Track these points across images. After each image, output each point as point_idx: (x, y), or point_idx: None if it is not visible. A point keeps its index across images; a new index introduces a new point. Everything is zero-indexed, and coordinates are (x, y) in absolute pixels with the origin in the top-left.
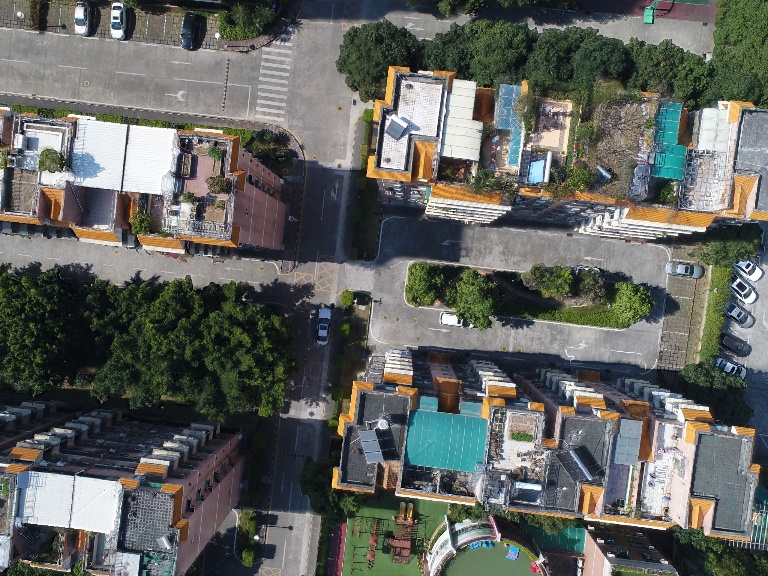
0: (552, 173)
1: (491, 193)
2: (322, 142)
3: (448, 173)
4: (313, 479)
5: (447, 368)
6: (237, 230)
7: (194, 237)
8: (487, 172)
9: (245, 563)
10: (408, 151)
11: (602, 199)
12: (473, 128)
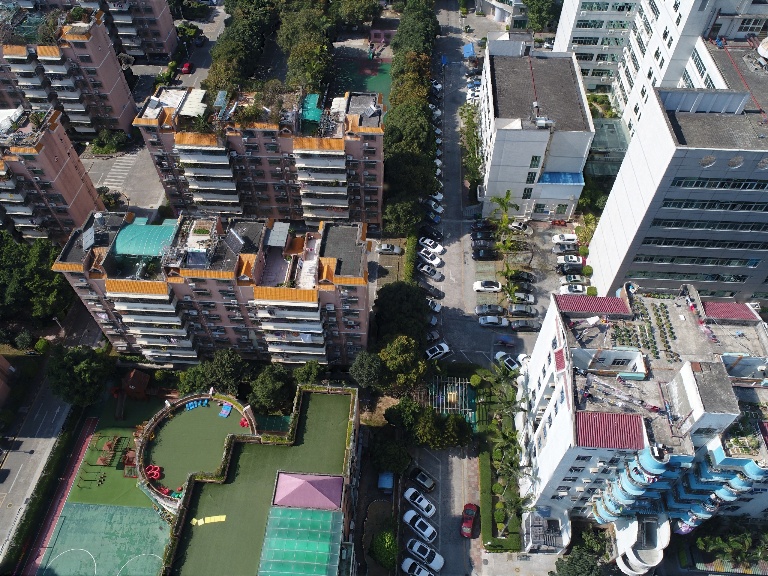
0: (236, 109)
1: (210, 137)
2: (143, 197)
3: (185, 128)
4: (57, 356)
5: None
6: (41, 146)
7: (11, 148)
8: None
9: None
10: (159, 113)
11: (270, 127)
12: (200, 106)
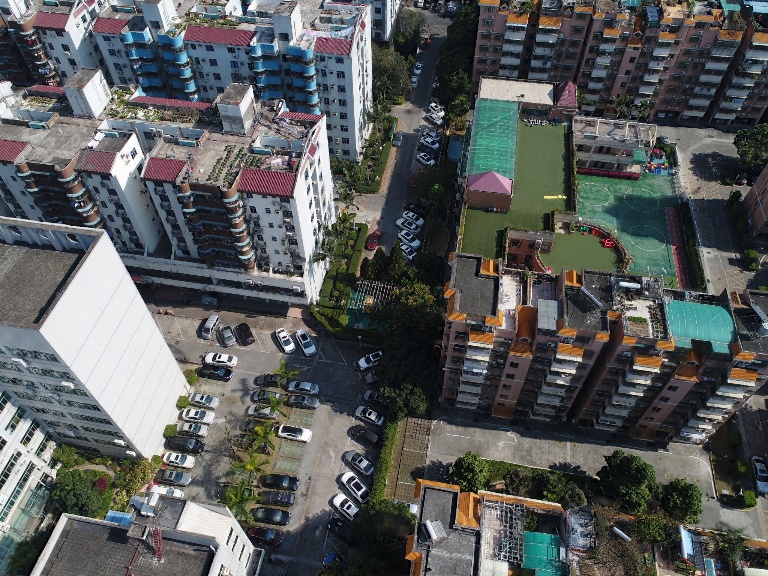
0: None
1: None
2: None
3: (767, 561)
4: None
5: (650, 415)
6: None
7: None
8: (731, 554)
9: (765, 288)
10: None
11: None
12: None
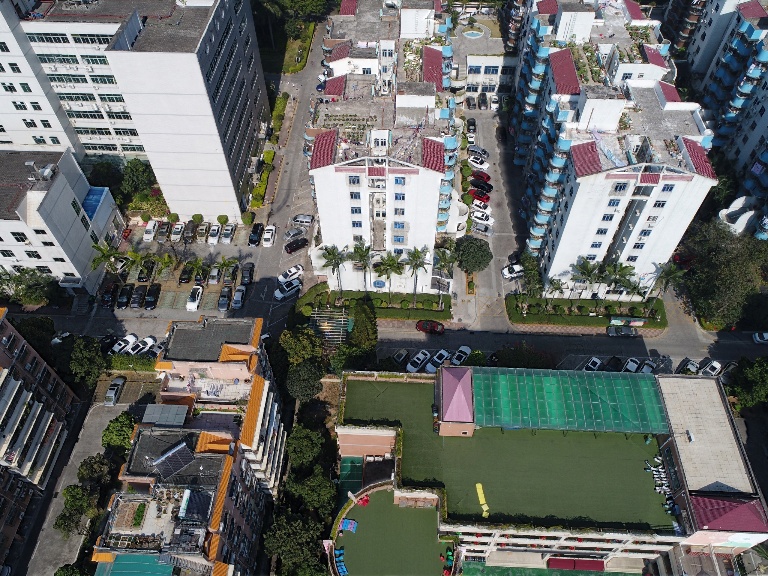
0: None
1: None
2: None
3: None
4: None
5: None
6: None
7: None
8: None
9: None
10: None
11: None
12: None
